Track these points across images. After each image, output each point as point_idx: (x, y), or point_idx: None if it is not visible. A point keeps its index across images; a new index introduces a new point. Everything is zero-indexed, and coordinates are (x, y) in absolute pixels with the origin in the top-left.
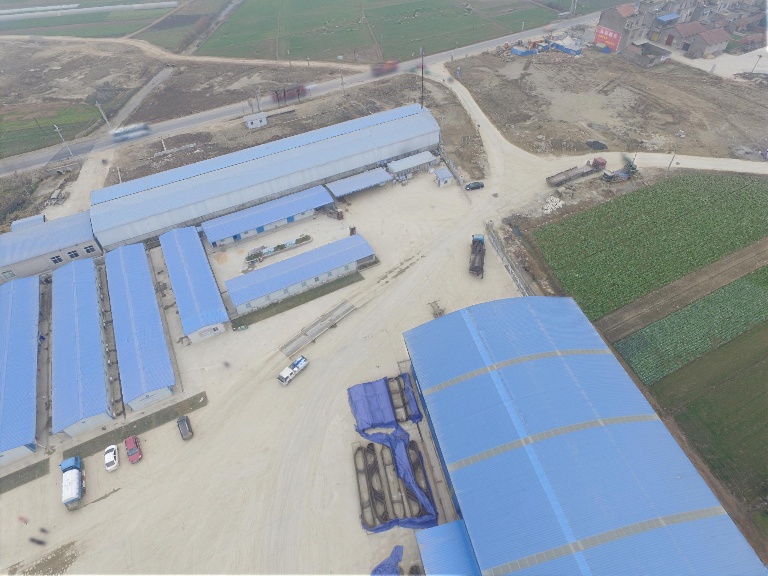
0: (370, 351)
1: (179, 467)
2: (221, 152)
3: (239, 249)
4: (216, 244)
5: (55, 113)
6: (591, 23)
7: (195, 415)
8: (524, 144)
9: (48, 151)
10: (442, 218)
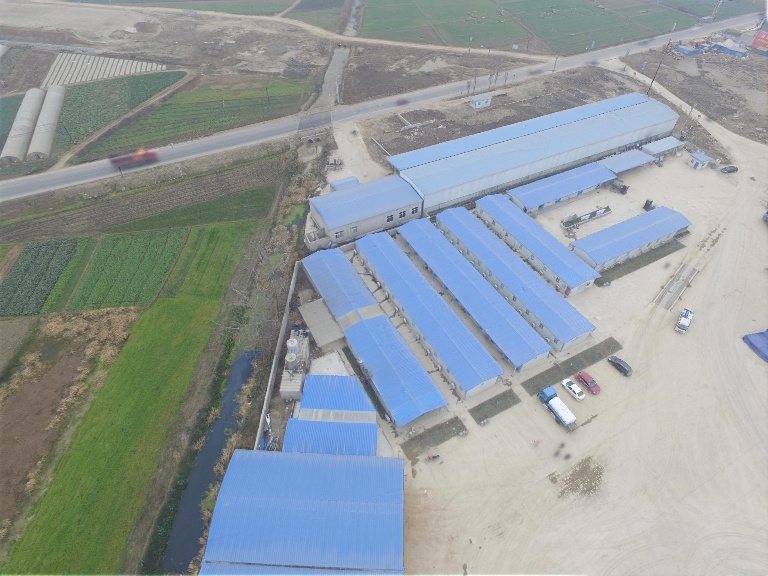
0: (737, 307)
1: (638, 398)
2: (464, 129)
3: (548, 216)
4: (526, 211)
5: (261, 85)
6: (734, 28)
7: (619, 356)
8: (748, 135)
9: (289, 120)
10: (718, 197)
